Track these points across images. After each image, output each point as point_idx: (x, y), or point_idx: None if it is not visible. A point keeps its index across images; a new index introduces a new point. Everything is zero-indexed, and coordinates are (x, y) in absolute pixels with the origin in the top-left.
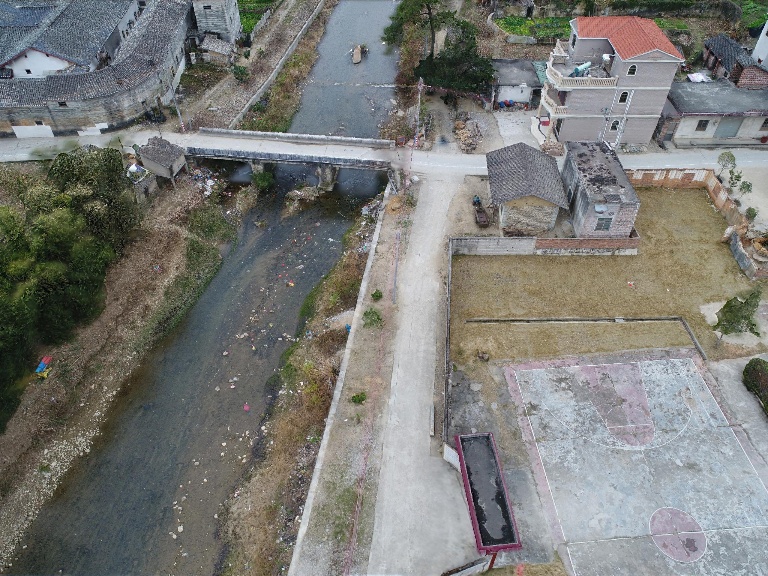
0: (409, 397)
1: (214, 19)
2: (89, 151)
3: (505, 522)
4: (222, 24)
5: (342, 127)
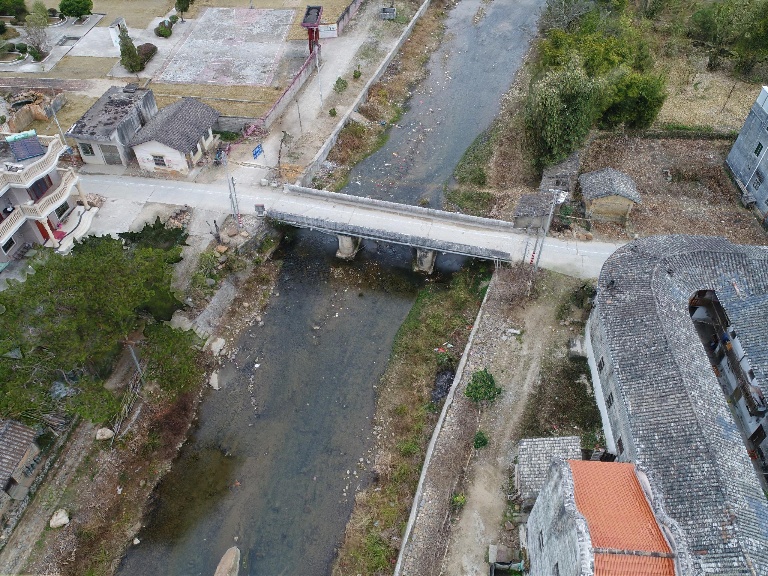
0: (330, 76)
1: None
2: None
3: None
4: None
5: (317, 327)
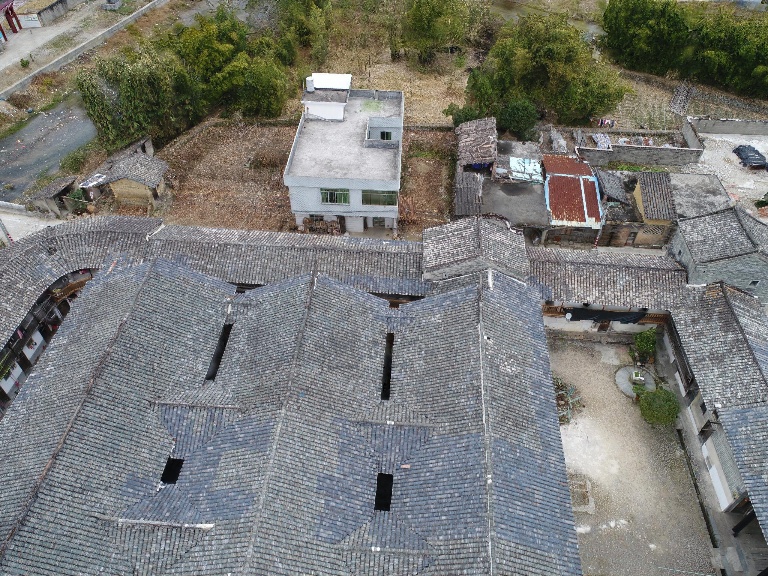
0: None
1: None
2: (99, 71)
3: (0, 0)
4: None
5: None
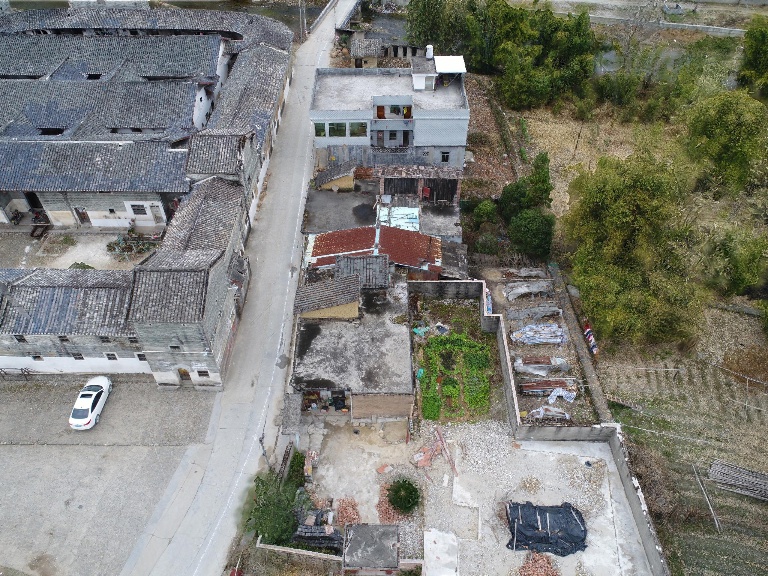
0: None
1: (144, 5)
2: None
3: None
4: (147, 8)
5: (285, 15)
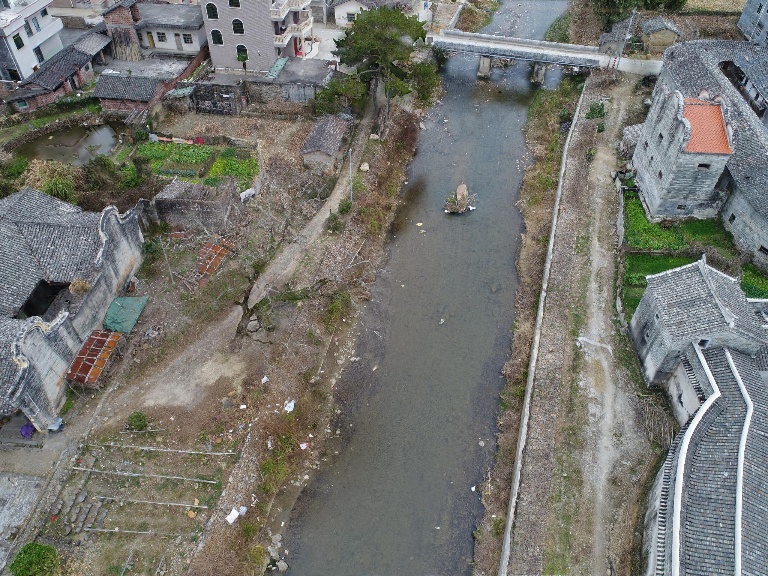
0: None
1: None
2: None
3: None
4: None
5: (477, 105)
